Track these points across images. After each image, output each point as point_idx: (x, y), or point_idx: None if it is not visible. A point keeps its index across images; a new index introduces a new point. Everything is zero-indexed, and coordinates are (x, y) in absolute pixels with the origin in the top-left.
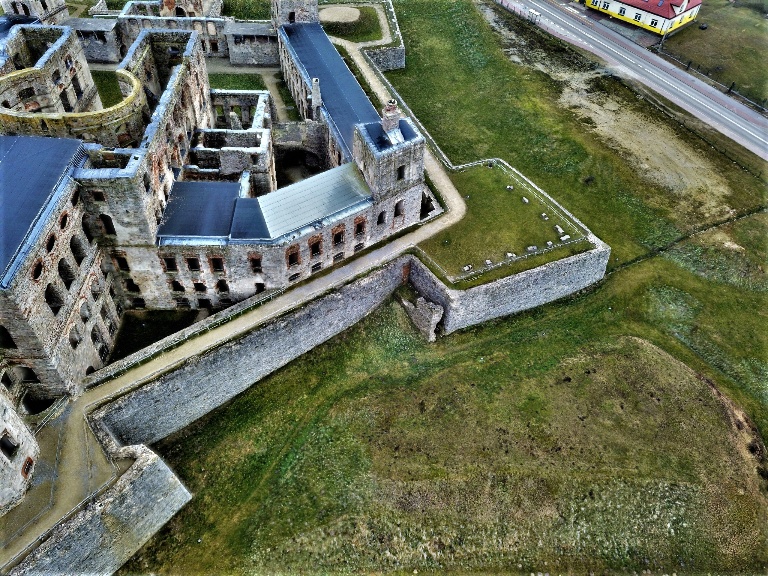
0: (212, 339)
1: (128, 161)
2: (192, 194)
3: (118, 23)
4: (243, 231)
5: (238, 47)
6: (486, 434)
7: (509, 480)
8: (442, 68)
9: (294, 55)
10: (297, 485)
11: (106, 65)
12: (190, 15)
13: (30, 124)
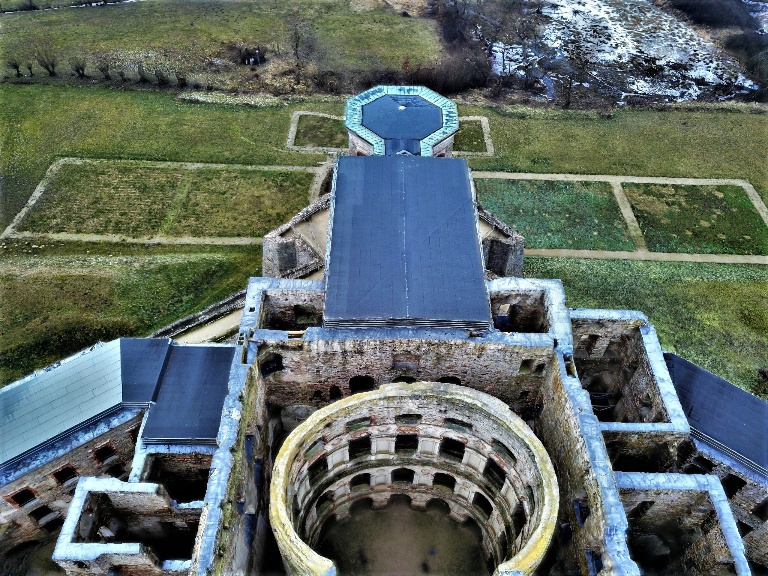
0: (223, 325)
1: (271, 330)
2: (216, 413)
3: None
4: (153, 348)
5: None
6: (0, 297)
7: (6, 274)
8: None
9: None
10: (178, 287)
11: None
12: None
13: None
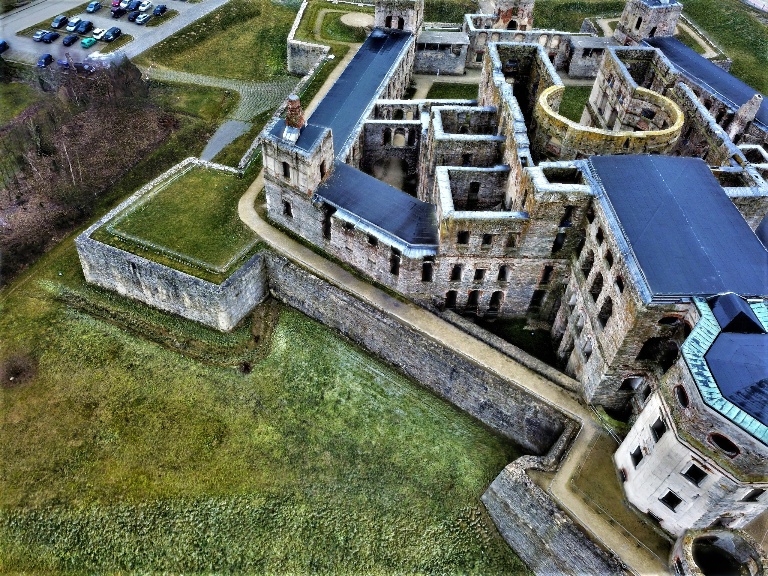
0: None
1: None
2: None
3: (469, 36)
4: None
5: (584, 60)
6: None
7: None
8: (761, 81)
9: (678, 70)
10: None
11: (453, 77)
12: (520, 28)
13: (615, 142)
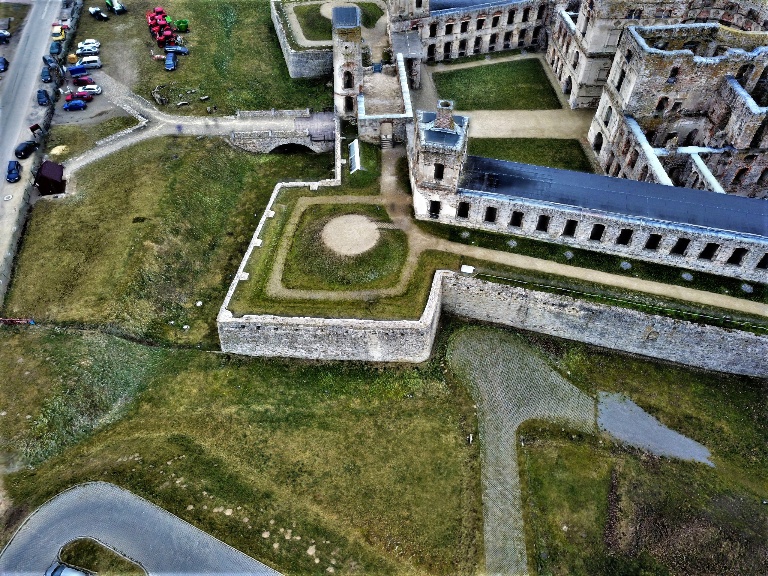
0: None
1: None
2: None
3: None
4: None
5: None
6: None
7: None
8: None
9: (485, 7)
10: None
11: None
12: None
13: None
